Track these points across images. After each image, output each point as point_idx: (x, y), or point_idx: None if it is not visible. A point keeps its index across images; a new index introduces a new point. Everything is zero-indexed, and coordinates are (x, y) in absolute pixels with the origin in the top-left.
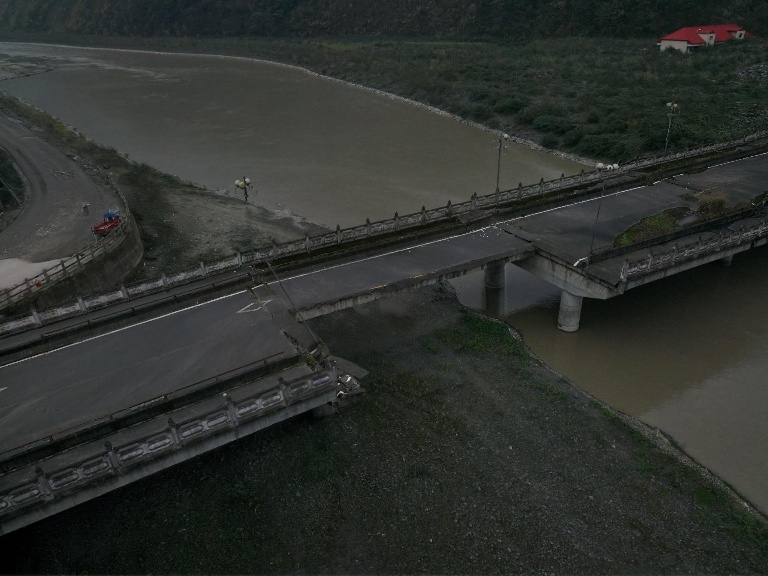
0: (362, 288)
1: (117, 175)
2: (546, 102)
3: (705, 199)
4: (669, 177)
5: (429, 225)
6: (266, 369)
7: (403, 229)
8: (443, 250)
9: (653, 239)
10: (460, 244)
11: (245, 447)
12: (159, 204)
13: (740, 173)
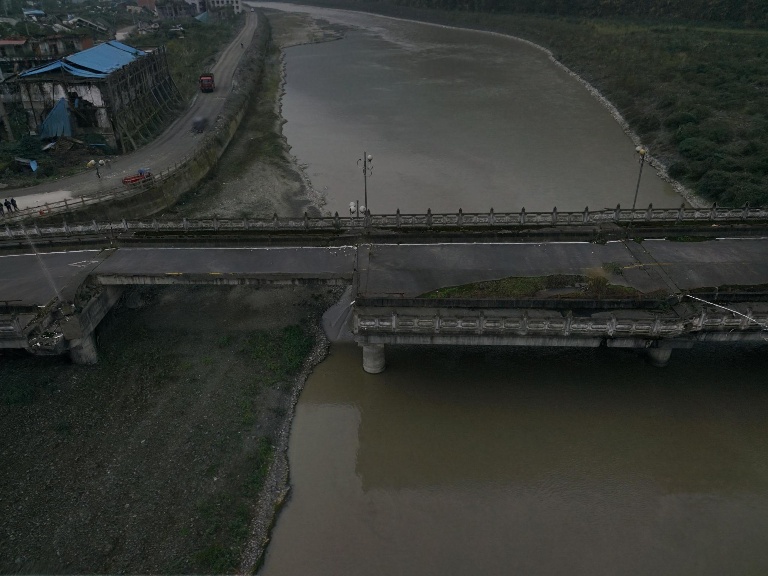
0: (161, 271)
1: (251, 138)
2: (726, 121)
3: (631, 274)
4: (637, 239)
5: (310, 232)
6: (6, 309)
7: (283, 230)
8: (276, 257)
9: (459, 300)
10: (299, 255)
11: (12, 364)
12: (240, 169)
13: (745, 254)
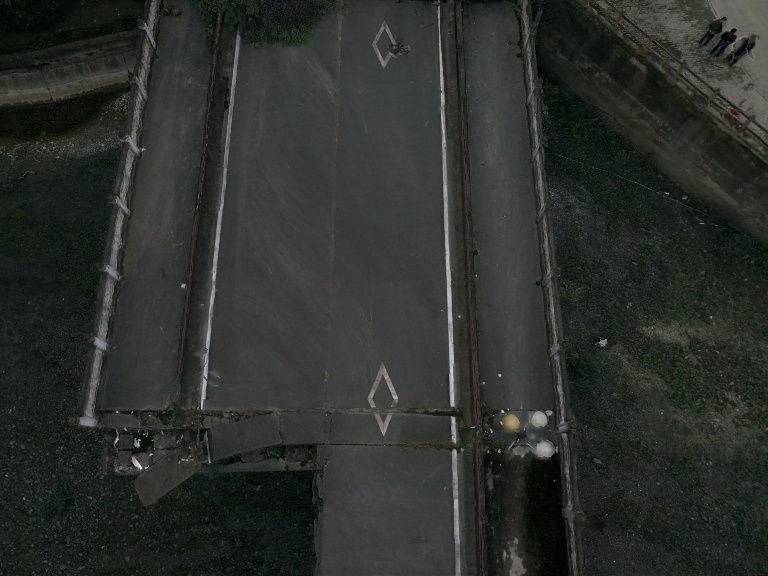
0: None
1: None
2: None
3: None
4: None
5: None
6: None
7: None
8: None
9: None
10: None
11: None
12: None
13: None
